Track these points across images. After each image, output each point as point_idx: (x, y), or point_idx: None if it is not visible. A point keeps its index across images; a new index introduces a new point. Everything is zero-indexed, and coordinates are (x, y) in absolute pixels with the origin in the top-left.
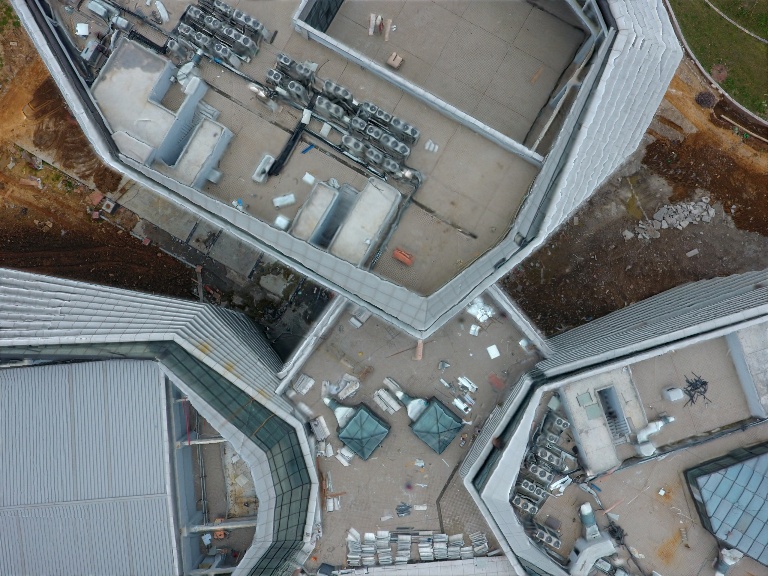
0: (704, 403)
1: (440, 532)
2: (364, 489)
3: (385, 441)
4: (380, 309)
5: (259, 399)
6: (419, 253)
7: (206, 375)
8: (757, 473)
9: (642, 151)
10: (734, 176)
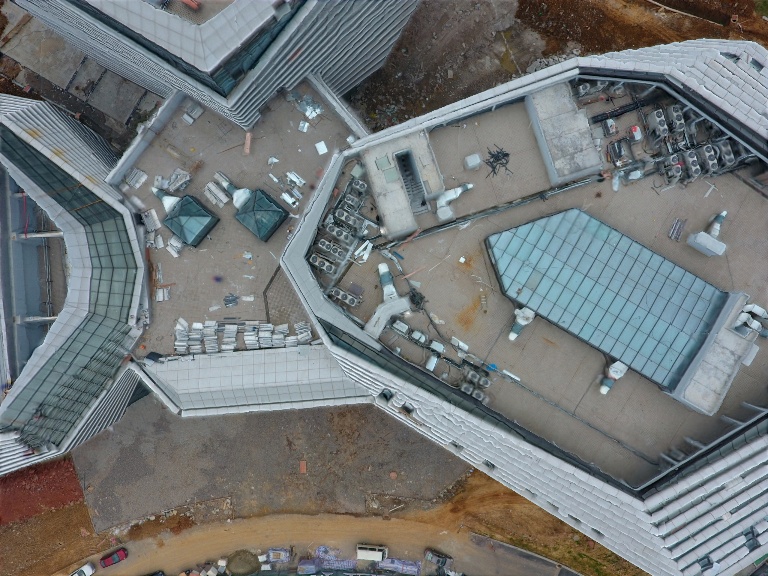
0: (506, 174)
1: (266, 322)
2: (193, 280)
3: (214, 233)
4: (184, 72)
5: (86, 184)
6: (208, 1)
7: (33, 157)
8: (548, 232)
9: (514, 4)
10: (604, 27)
